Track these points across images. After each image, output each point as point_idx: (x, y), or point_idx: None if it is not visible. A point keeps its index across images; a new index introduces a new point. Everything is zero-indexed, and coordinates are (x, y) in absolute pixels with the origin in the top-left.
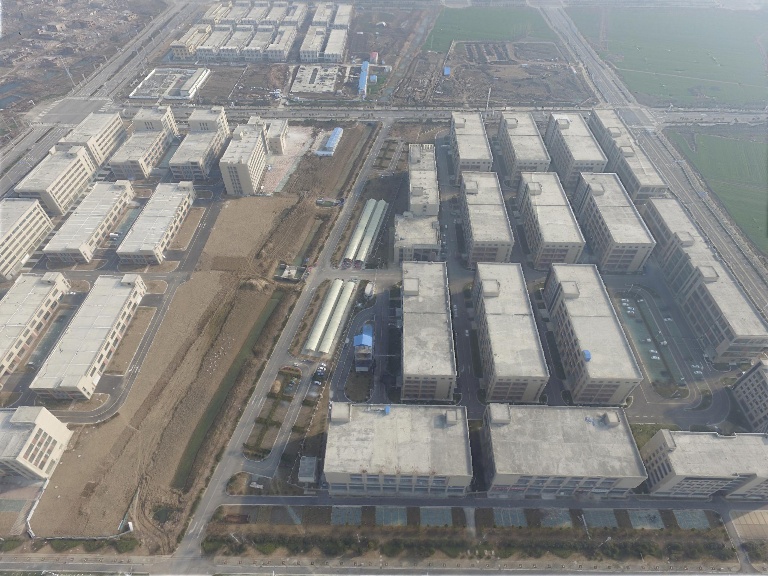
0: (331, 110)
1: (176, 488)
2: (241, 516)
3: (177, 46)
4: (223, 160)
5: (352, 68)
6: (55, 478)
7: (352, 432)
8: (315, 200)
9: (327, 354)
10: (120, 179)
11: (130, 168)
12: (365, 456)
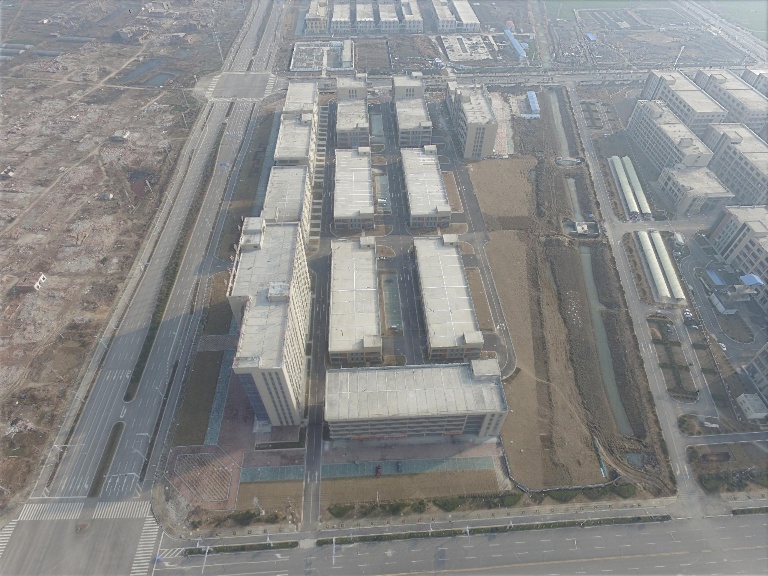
0: (505, 76)
1: (626, 434)
2: (722, 454)
3: (313, 19)
4: (473, 121)
5: (494, 37)
6: (504, 433)
7: None
8: (554, 160)
9: (682, 300)
10: (343, 148)
11: (357, 136)
12: None
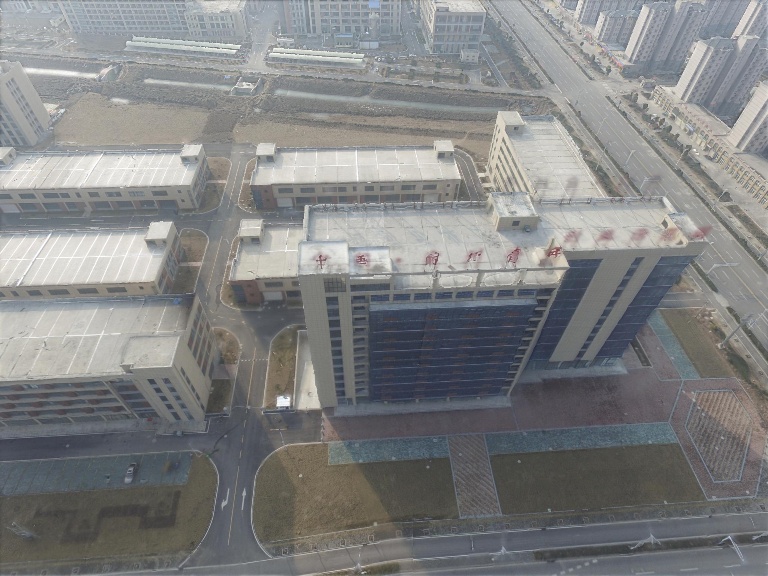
0: None
1: None
2: (513, 74)
3: None
4: None
5: None
6: None
7: (454, 8)
8: None
9: None
10: None
11: None
12: (469, 5)
